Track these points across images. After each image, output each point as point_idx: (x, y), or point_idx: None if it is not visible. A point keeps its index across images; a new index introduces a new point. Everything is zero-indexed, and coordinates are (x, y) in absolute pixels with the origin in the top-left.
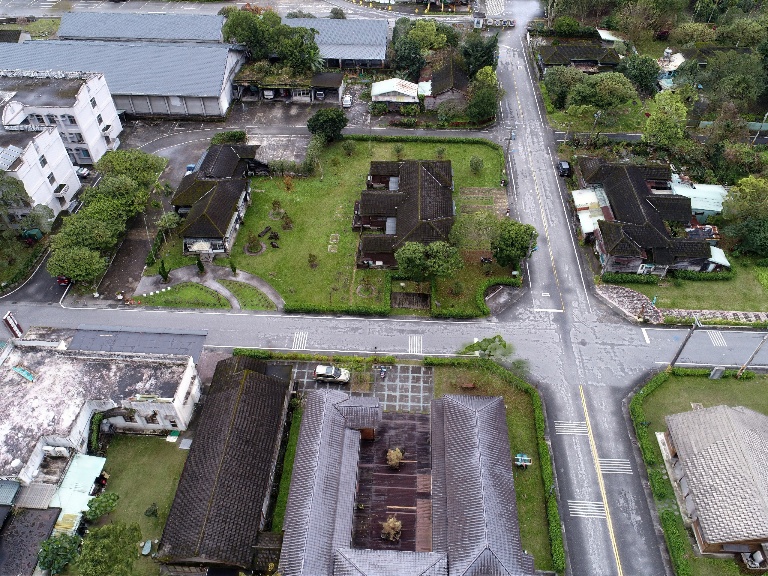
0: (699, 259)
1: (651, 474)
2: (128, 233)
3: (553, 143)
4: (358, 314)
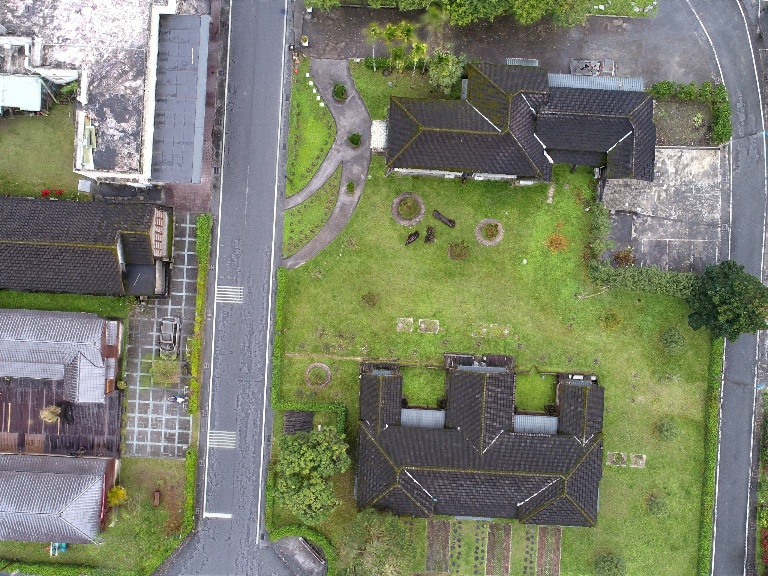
0: None
1: None
2: None
3: None
4: None
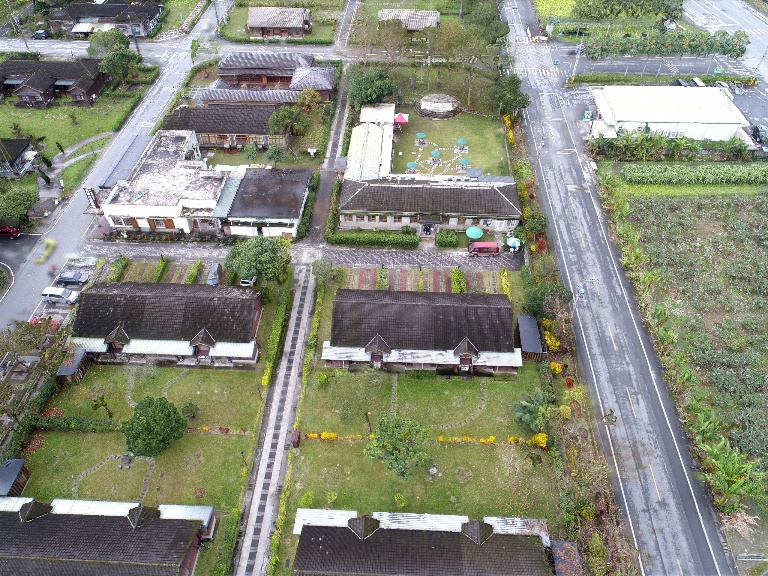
0: (156, 8)
1: (269, 41)
2: None
3: (4, 38)
4: (135, 107)
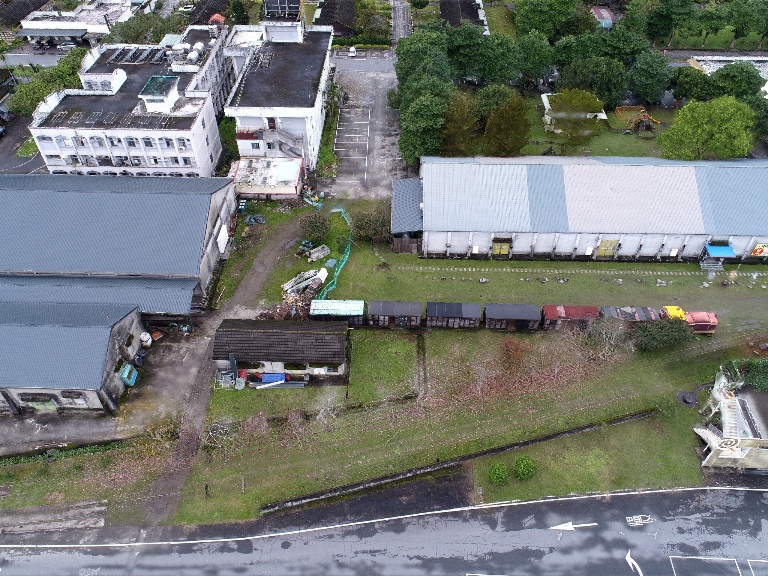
0: None
1: None
2: None
3: None
4: None
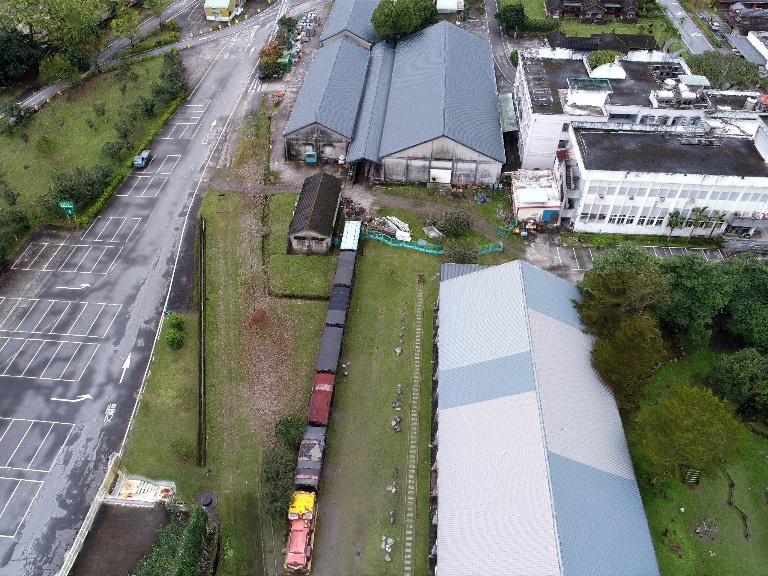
0: None
1: None
2: None
3: None
4: None
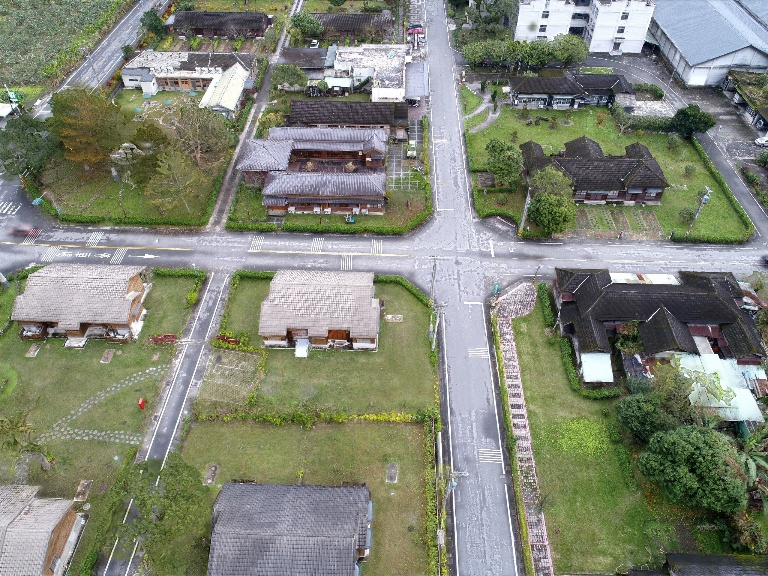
0: None
1: None
2: (522, 74)
3: None
4: None
